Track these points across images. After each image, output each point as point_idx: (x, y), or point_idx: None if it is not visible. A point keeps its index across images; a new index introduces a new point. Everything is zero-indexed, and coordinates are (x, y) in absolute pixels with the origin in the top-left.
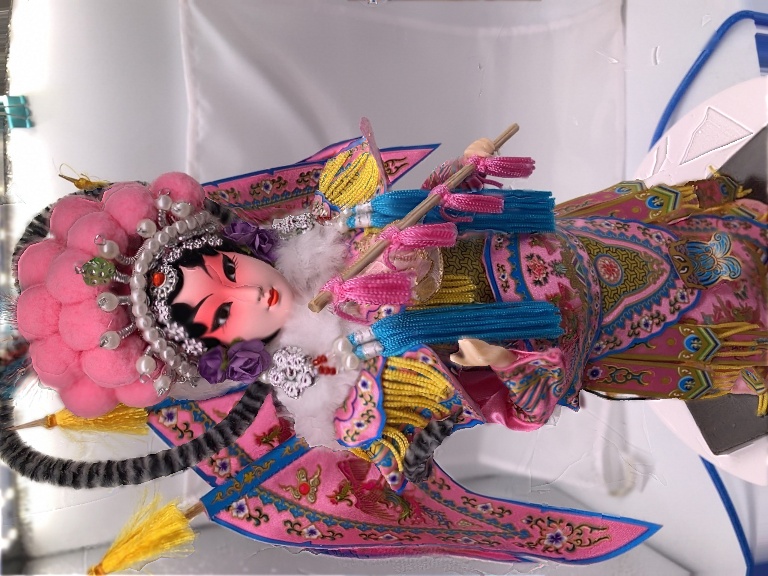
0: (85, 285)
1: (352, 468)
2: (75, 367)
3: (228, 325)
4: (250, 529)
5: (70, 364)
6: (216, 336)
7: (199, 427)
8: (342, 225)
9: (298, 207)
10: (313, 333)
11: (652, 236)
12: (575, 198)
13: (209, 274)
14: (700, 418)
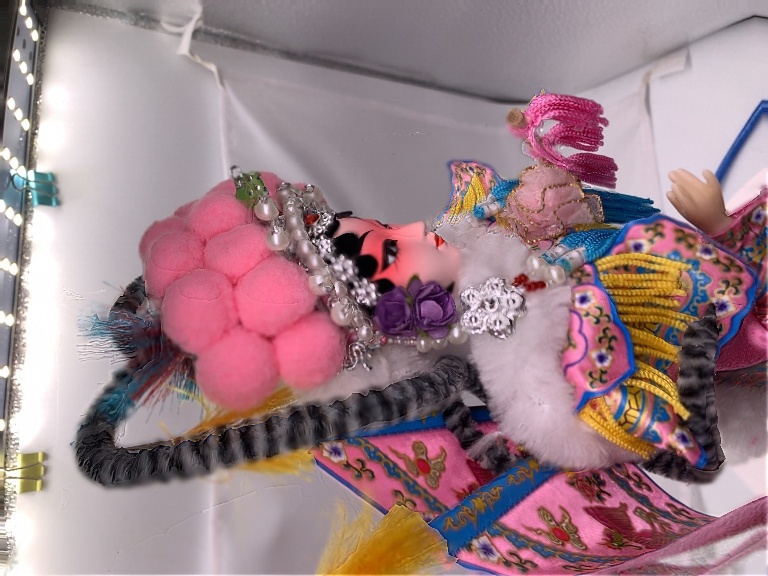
0: (238, 204)
1: (606, 517)
2: (229, 298)
3: (400, 258)
4: (517, 575)
5: (224, 291)
6: (388, 277)
7: (378, 467)
8: (471, 219)
9: None
10: (499, 252)
11: None
12: None
13: (363, 220)
14: None
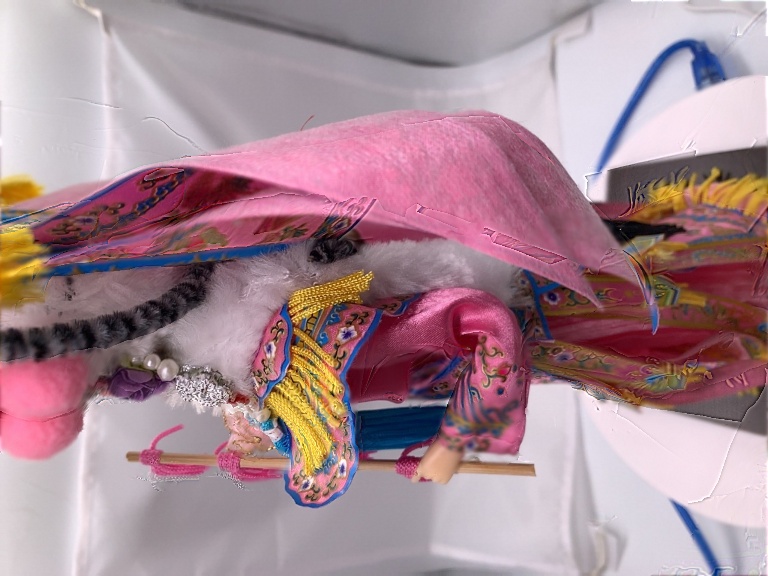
0: None
1: None
2: None
3: None
4: None
5: None
6: None
7: None
8: (244, 416)
9: None
10: None
11: None
12: None
13: None
14: (613, 177)
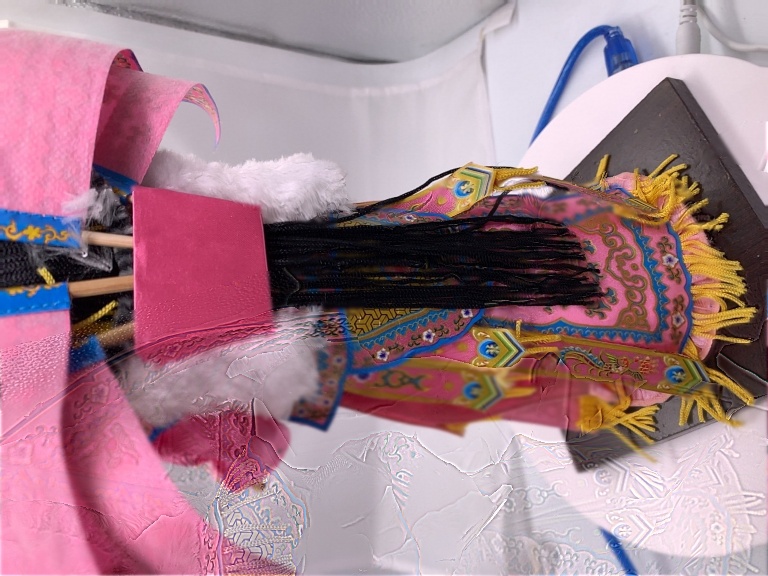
0: None
1: None
2: None
3: None
4: None
5: None
6: None
7: None
8: None
9: (214, 357)
10: None
11: (595, 571)
12: (546, 471)
13: None
14: None
